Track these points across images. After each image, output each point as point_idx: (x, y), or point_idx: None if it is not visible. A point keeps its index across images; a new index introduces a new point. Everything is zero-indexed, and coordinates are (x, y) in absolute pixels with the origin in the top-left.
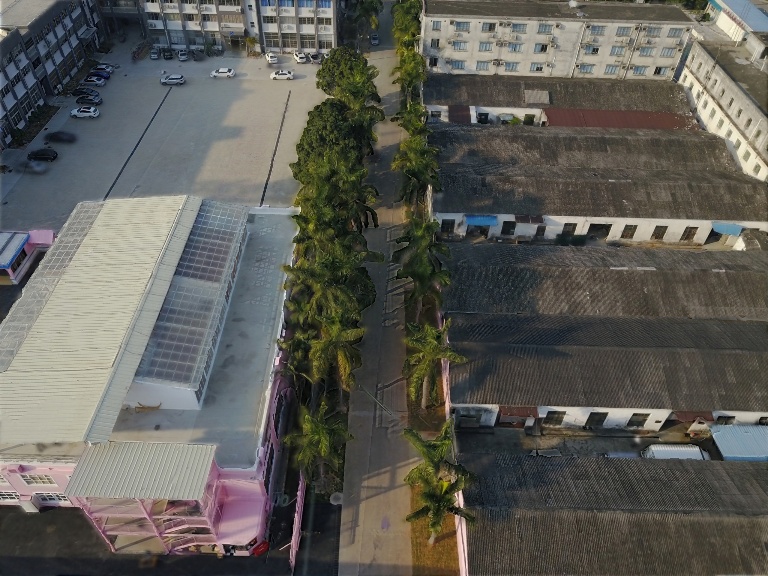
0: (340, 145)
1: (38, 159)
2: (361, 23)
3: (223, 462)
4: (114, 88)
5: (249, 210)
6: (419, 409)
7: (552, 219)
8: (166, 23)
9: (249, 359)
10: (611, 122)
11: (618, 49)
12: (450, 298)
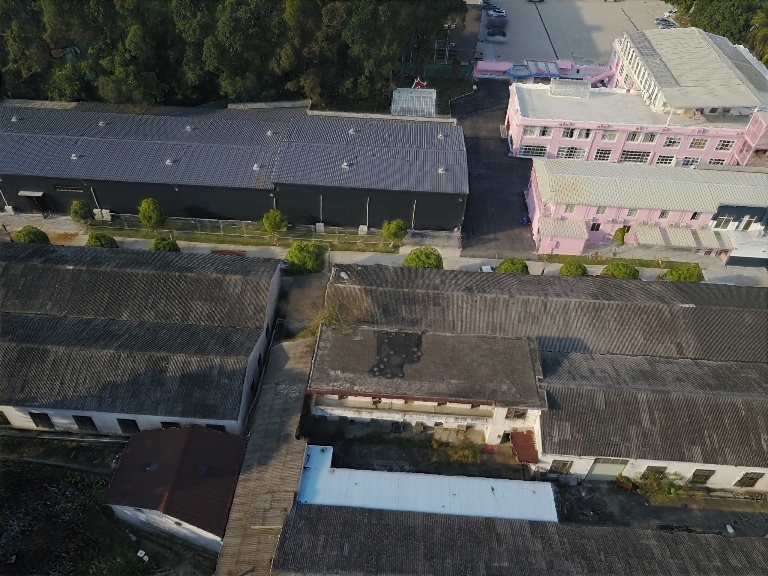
0: (744, 16)
1: (495, 35)
2: None
3: None
4: (497, 2)
5: None
6: None
7: None
8: None
9: None
10: None
11: None
12: None
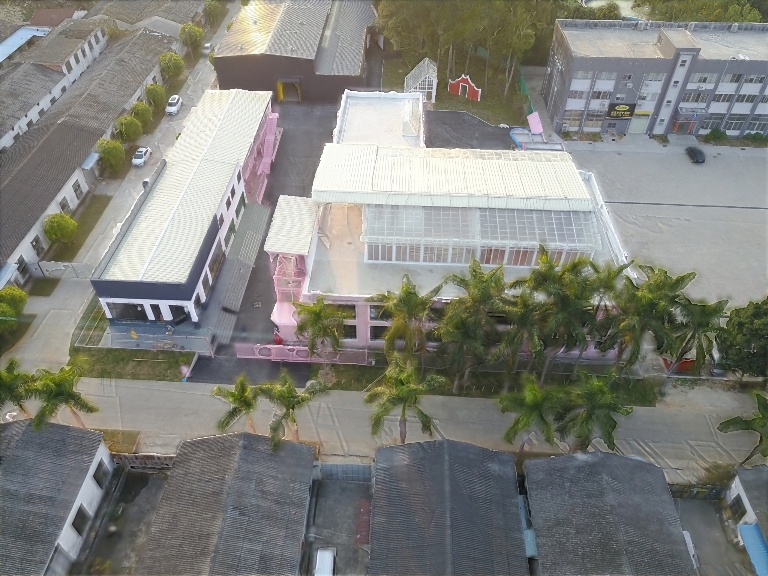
0: None
1: (689, 154)
2: None
3: (316, 279)
4: None
5: (598, 249)
6: None
7: None
8: None
9: (417, 284)
10: None
11: None
12: (545, 469)
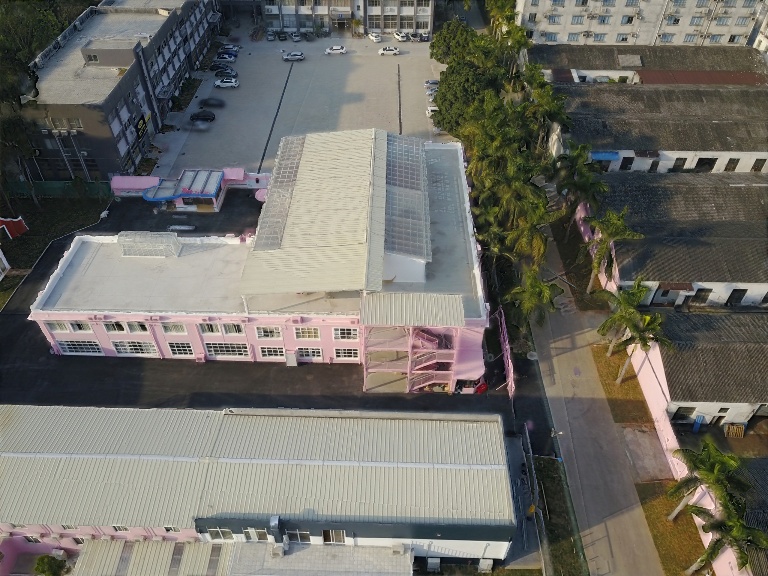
0: (481, 94)
1: (200, 120)
2: (446, 8)
3: None
4: (243, 64)
5: None
6: (583, 295)
7: (666, 154)
8: (281, 8)
9: (452, 249)
10: (699, 80)
11: (697, 19)
12: None
